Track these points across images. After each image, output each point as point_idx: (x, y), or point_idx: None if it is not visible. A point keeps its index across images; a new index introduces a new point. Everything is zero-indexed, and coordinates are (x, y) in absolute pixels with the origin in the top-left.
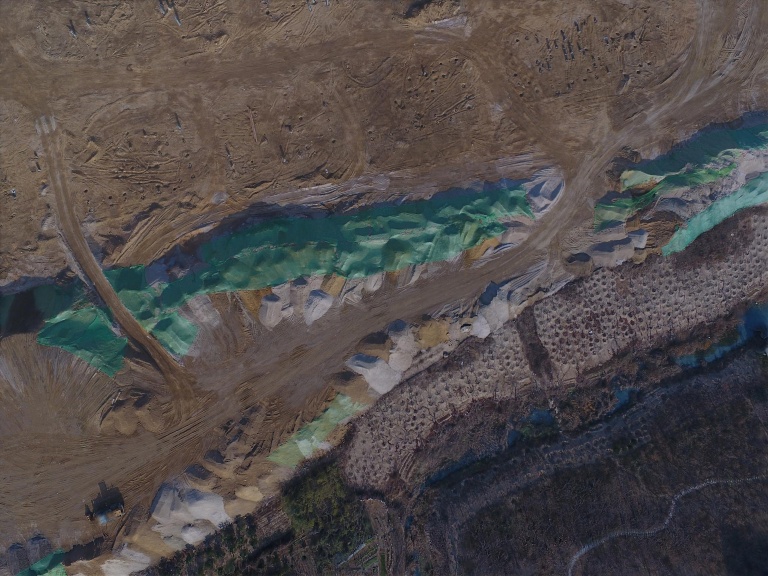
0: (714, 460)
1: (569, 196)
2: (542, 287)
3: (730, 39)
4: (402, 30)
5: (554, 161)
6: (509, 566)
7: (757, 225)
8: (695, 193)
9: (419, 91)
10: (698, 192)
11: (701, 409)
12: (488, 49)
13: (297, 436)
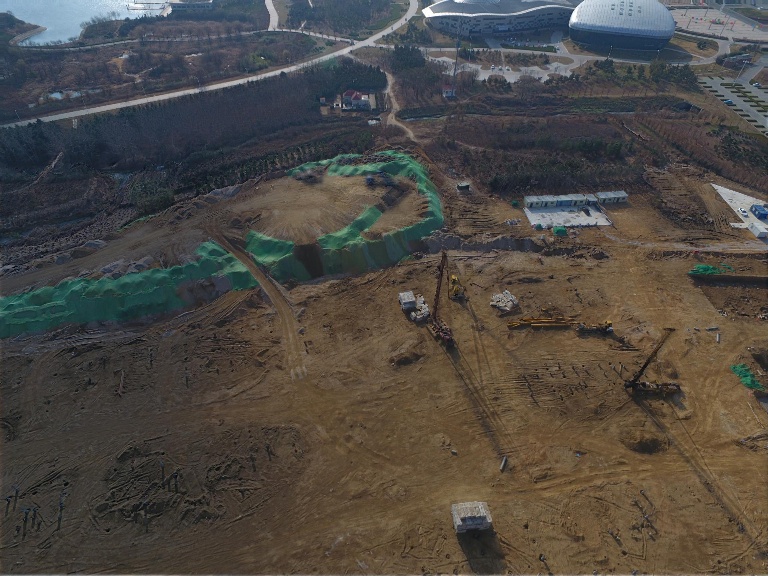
0: None
1: None
2: None
3: None
4: None
5: None
6: (62, 186)
7: None
8: None
9: None
10: None
11: None
12: None
13: None
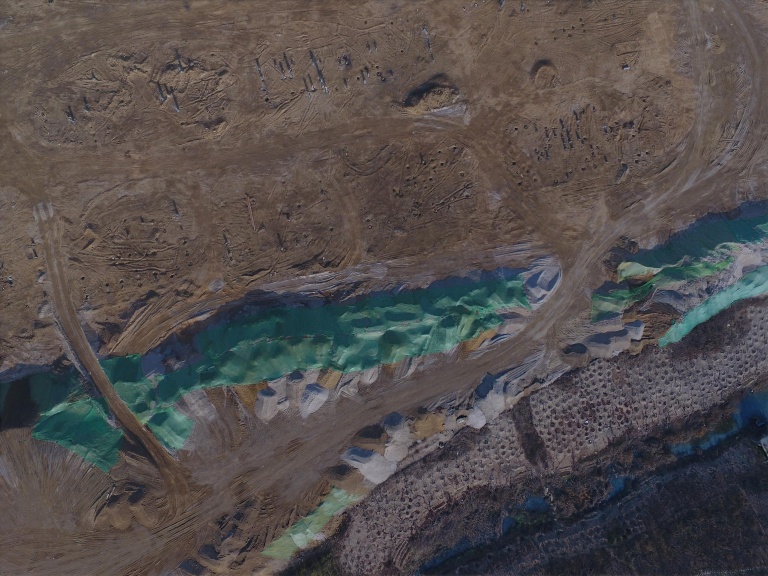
0: (708, 551)
1: (566, 286)
2: (538, 378)
3: (728, 129)
4: (401, 118)
5: (552, 250)
6: None
7: (753, 316)
8: (692, 287)
9: (417, 179)
10: (695, 286)
11: (696, 499)
12: (487, 137)
13: (292, 530)
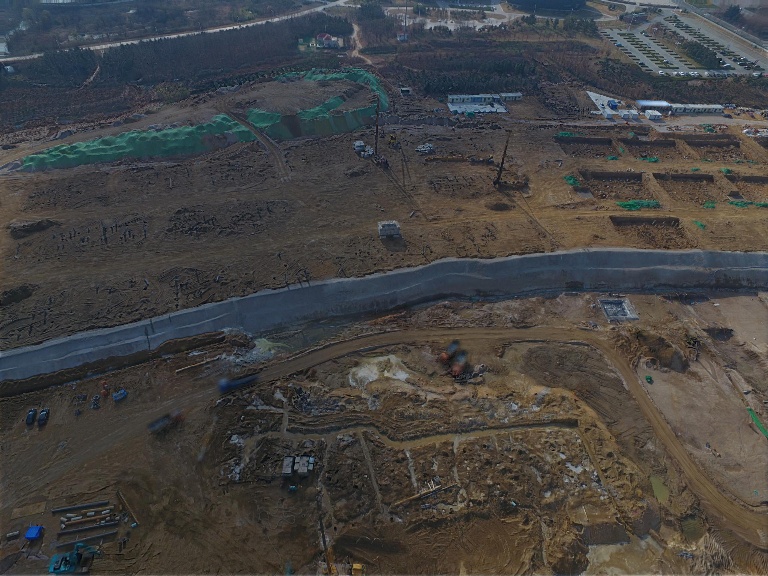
0: None
1: None
2: None
3: None
4: (59, 219)
5: None
6: None
7: None
8: None
9: None
10: None
11: None
12: None
13: None
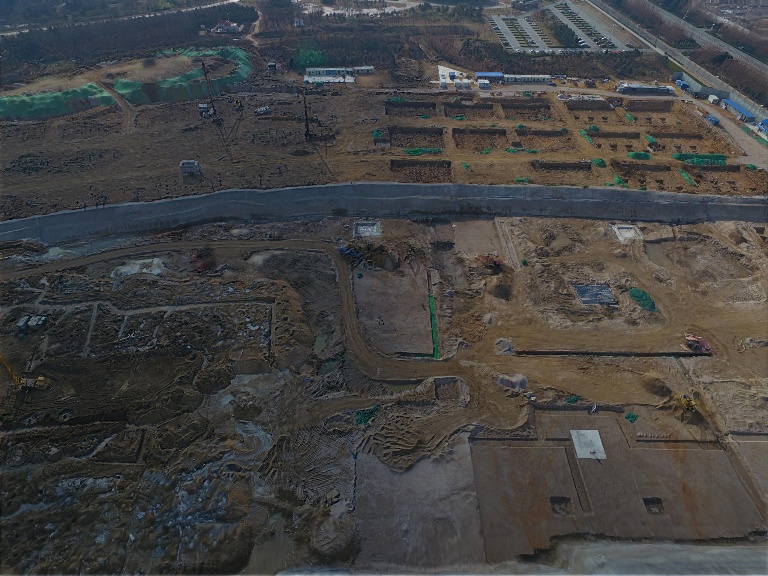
0: None
1: None
2: None
3: None
4: None
5: None
6: (3, 66)
7: None
8: None
9: None
10: None
11: None
12: None
13: None
